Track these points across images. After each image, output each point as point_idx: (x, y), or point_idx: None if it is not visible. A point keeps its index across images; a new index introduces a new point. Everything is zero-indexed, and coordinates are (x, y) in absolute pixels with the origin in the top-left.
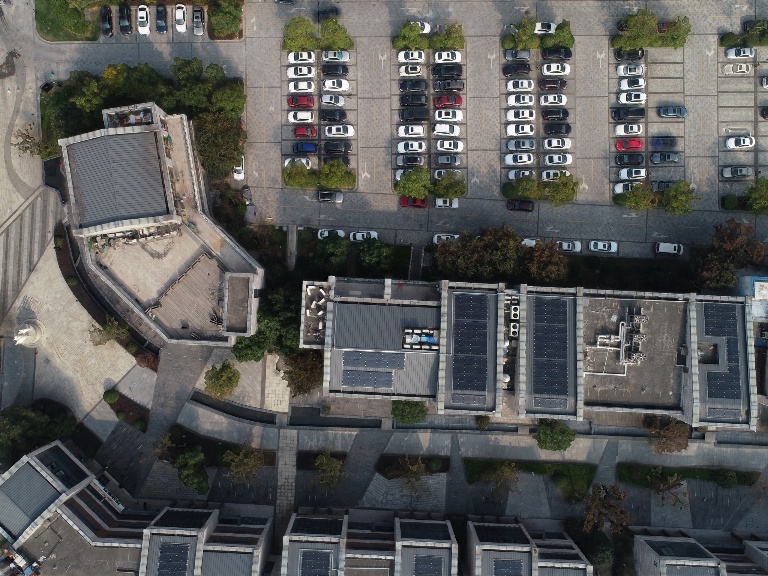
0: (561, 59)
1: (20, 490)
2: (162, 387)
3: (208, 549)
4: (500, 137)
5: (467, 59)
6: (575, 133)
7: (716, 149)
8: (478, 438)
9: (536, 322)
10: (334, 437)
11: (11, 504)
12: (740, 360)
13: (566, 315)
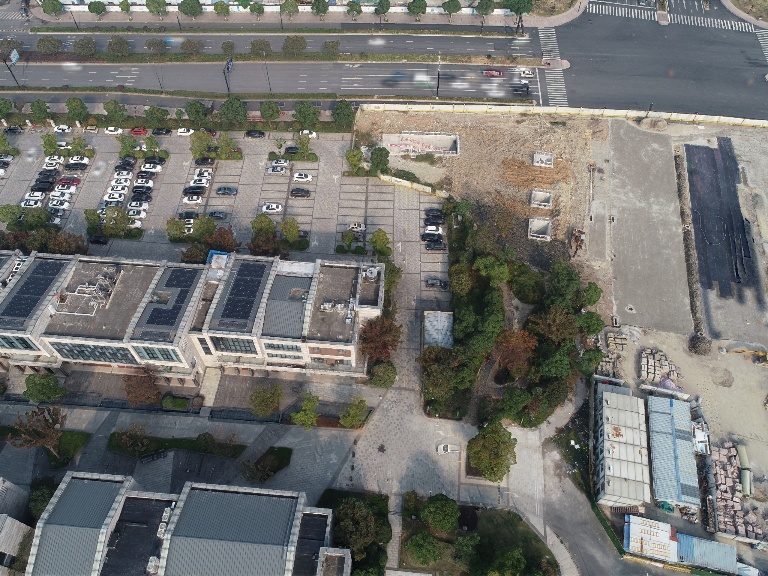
0: (156, 163)
1: None
2: None
3: None
4: (99, 203)
5: (94, 163)
6: (155, 202)
7: (255, 213)
8: None
9: (32, 274)
10: None
11: None
12: (185, 302)
13: (59, 271)
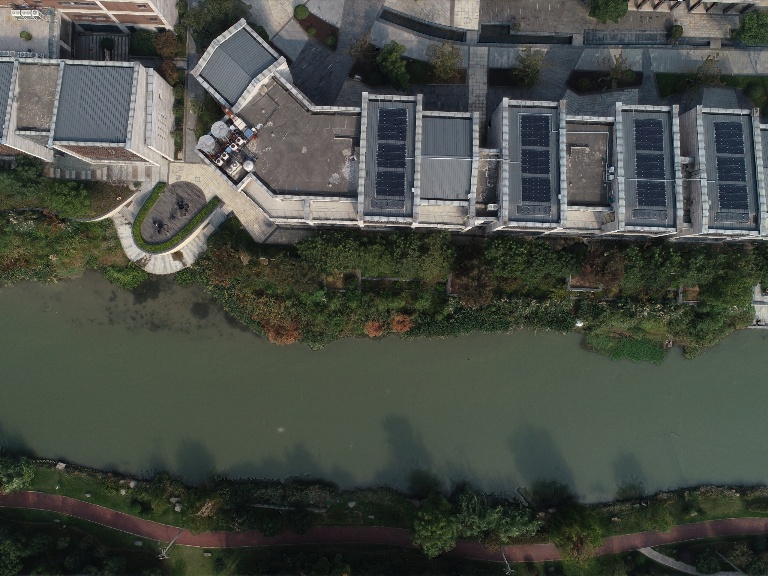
0: None
1: (239, 51)
2: (351, 6)
3: (426, 115)
4: None
5: None
6: None
7: None
8: (670, 53)
9: None
10: (525, 54)
11: (231, 63)
12: None
13: None
